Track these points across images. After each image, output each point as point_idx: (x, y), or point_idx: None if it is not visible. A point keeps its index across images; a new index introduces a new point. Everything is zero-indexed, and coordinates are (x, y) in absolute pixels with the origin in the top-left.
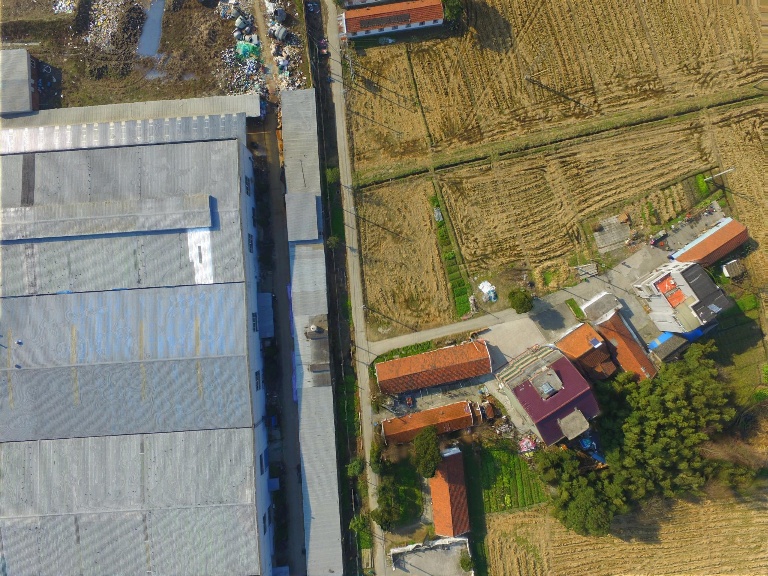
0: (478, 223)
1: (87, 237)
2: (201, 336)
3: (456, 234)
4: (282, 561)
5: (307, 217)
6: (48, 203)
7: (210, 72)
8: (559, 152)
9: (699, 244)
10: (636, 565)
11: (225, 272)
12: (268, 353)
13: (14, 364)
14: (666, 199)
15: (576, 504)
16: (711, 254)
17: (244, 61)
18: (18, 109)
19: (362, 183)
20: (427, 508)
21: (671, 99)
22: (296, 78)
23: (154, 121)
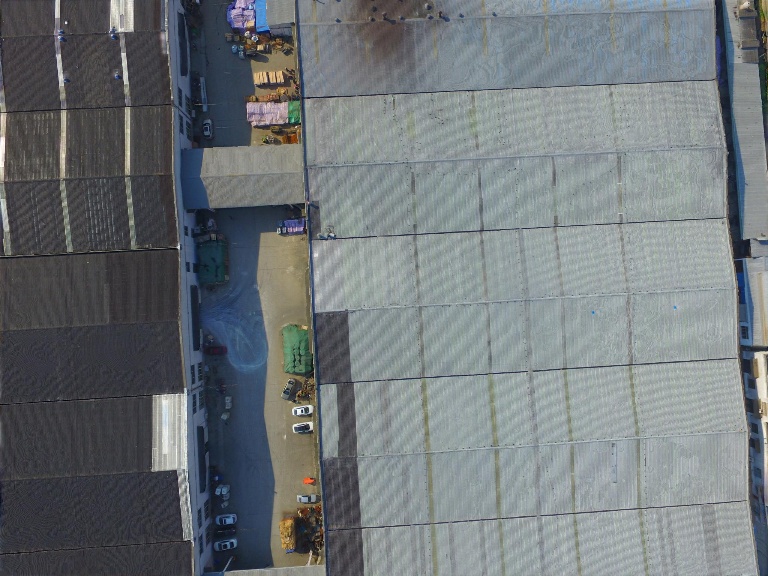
0: None
1: None
2: None
3: None
4: None
5: None
6: None
7: None
8: None
9: None
10: None
11: None
12: None
13: (490, 12)
14: None
15: None
16: None
17: None
18: None
19: None
20: None
21: None
22: None
23: None
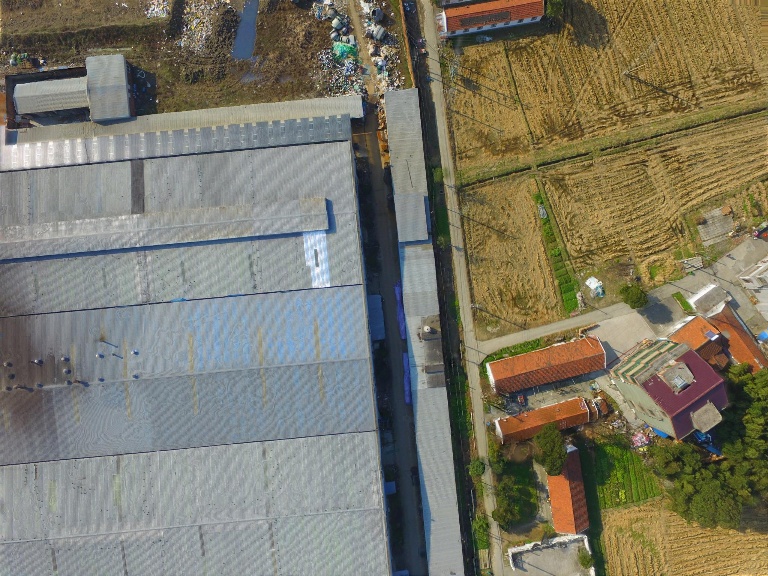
0: (582, 219)
1: (201, 243)
2: (321, 340)
3: (561, 231)
4: (400, 565)
5: (416, 217)
6: (159, 210)
7: (307, 74)
8: (659, 146)
9: None
10: (752, 556)
11: (342, 275)
12: (378, 356)
13: (131, 374)
14: (767, 191)
15: (703, 497)
16: None
17: (342, 62)
18: (117, 115)
19: (465, 182)
20: (542, 506)
21: (767, 91)
22: (395, 78)
23: (257, 124)
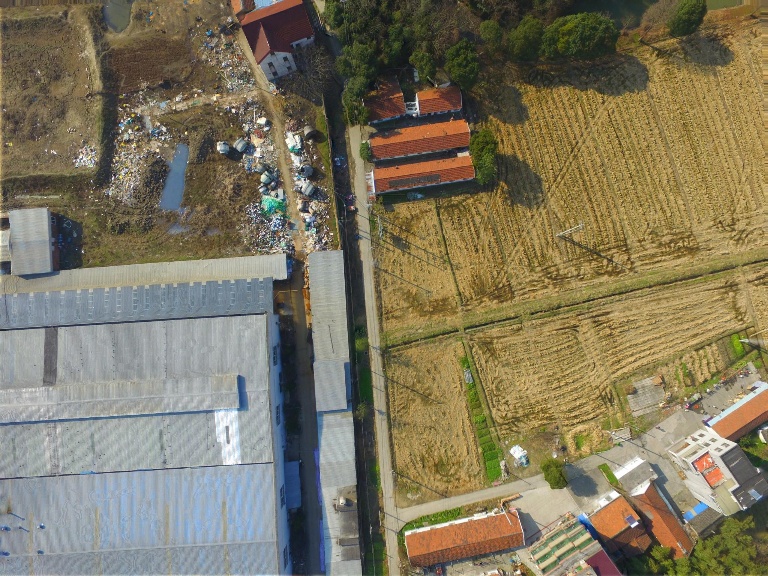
0: (509, 385)
1: (111, 417)
2: (229, 520)
3: (487, 396)
4: None
5: (336, 386)
6: (71, 381)
7: (235, 227)
8: (591, 311)
9: (736, 412)
10: None
11: (253, 452)
12: (295, 520)
13: (36, 549)
14: (701, 360)
15: None
16: (748, 424)
17: (270, 217)
18: (39, 271)
19: (391, 344)
20: None
21: (706, 257)
22: (323, 234)
23: (178, 285)
